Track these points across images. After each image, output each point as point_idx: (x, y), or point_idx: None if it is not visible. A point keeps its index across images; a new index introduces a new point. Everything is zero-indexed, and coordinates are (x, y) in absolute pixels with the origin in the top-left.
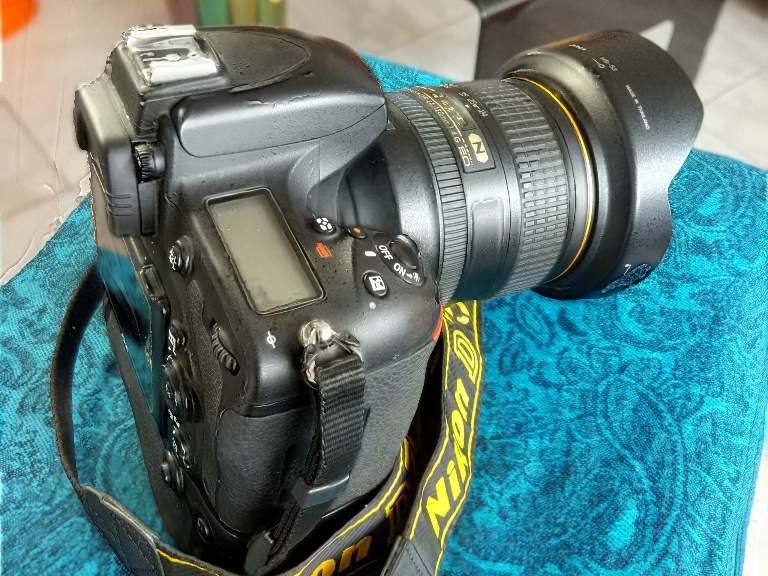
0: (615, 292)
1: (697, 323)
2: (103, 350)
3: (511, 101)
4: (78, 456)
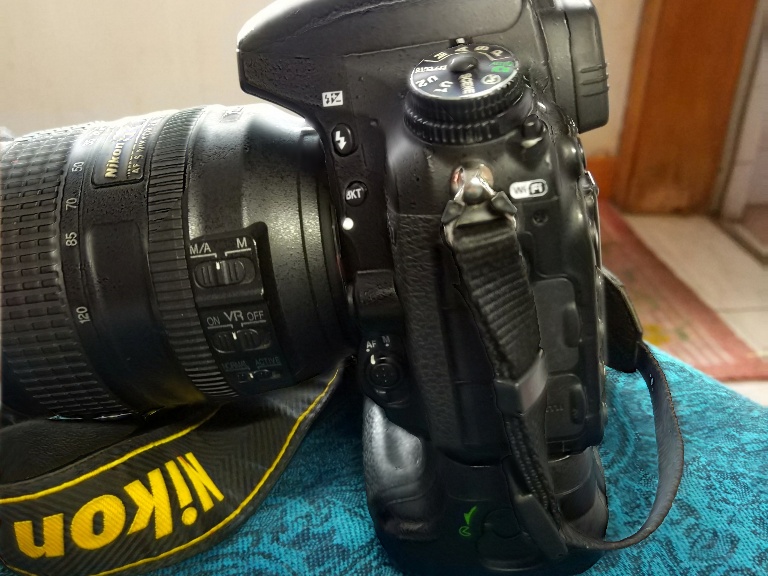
0: None
1: None
2: (618, 575)
3: (49, 136)
4: (655, 467)
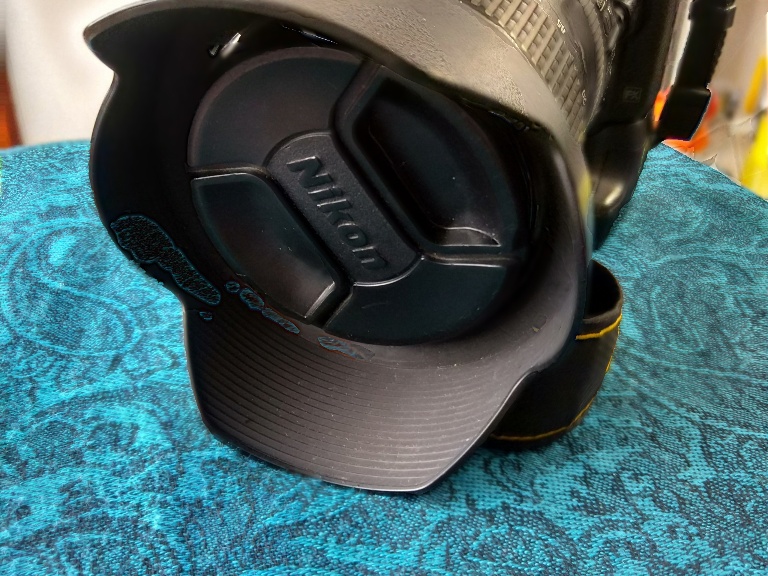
0: (160, 279)
1: (6, 466)
2: None
3: None
4: None
